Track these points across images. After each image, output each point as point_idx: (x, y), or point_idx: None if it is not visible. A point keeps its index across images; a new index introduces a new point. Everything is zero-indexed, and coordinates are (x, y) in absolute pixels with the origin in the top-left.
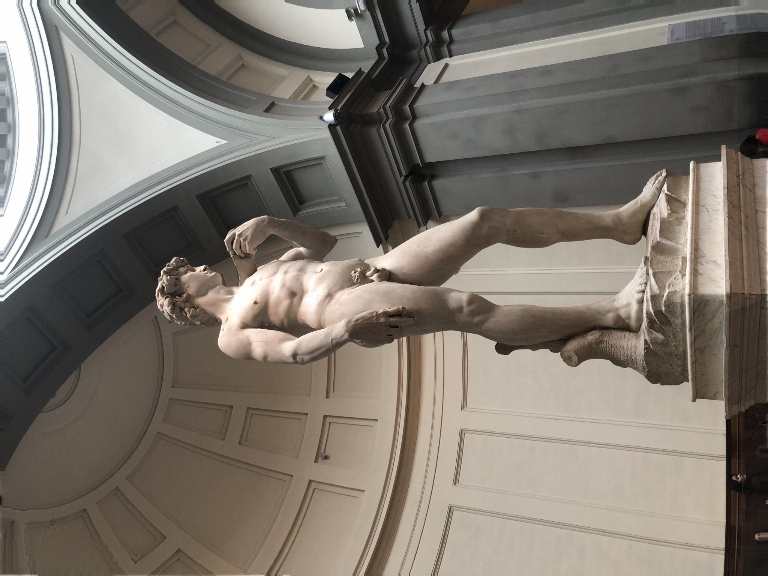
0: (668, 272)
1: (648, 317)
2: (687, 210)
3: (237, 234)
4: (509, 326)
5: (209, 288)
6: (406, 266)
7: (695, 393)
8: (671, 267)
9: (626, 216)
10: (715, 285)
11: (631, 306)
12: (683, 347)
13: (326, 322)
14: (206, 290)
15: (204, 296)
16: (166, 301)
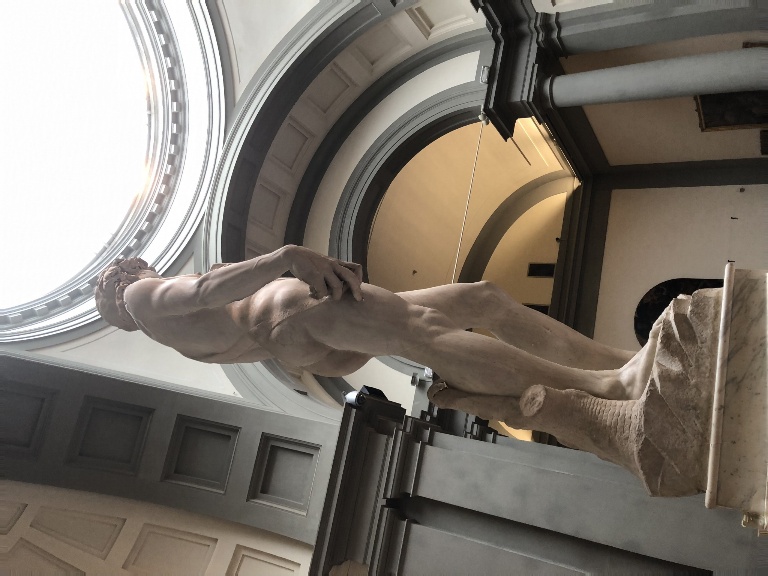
0: None
1: (664, 329)
2: None
3: None
4: (470, 342)
5: None
6: None
7: (716, 488)
8: None
9: None
10: None
11: (640, 359)
12: (708, 390)
13: (259, 295)
14: None
15: None
16: (113, 267)
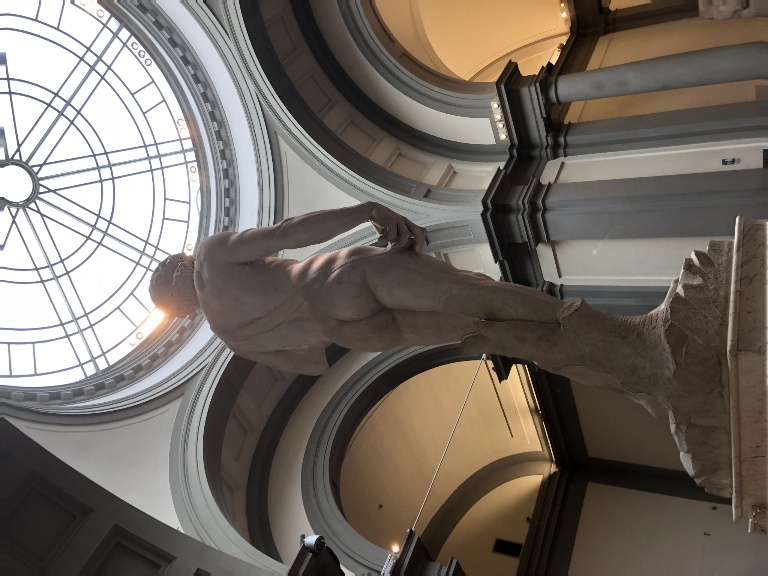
0: None
1: None
2: None
3: None
4: None
5: None
6: None
7: (736, 339)
8: None
9: None
10: None
11: None
12: (725, 291)
13: None
14: None
15: None
16: None
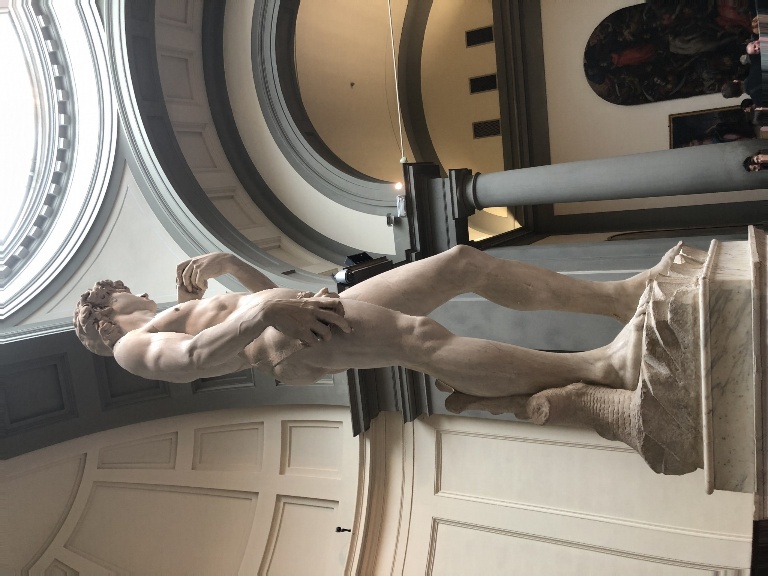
0: (678, 283)
1: (648, 335)
2: (705, 262)
3: (193, 260)
4: (466, 356)
5: (137, 309)
6: (362, 294)
7: (713, 477)
8: (682, 281)
9: (632, 285)
10: (739, 276)
11: (628, 345)
12: (696, 390)
13: None
14: (133, 309)
15: (128, 314)
16: (84, 307)
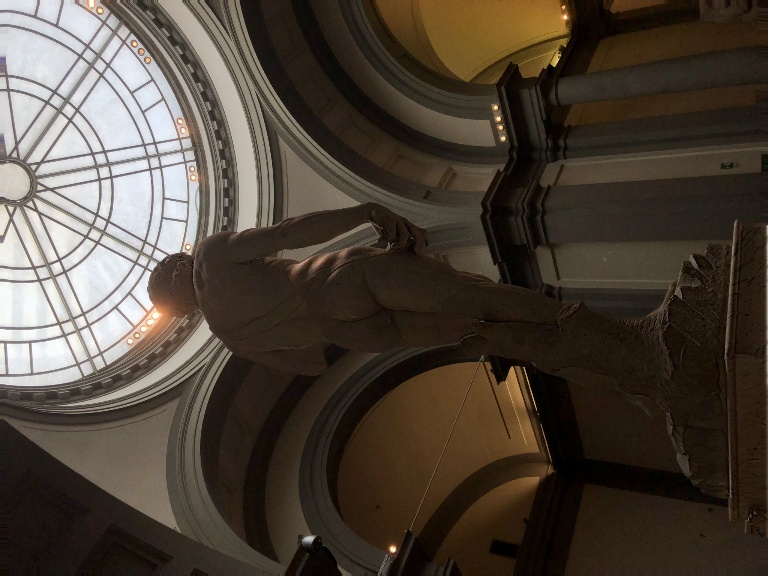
0: None
1: (685, 265)
2: None
3: None
4: None
5: None
6: None
7: (734, 342)
8: None
9: None
10: None
11: None
12: (723, 294)
13: None
14: None
15: None
16: None
